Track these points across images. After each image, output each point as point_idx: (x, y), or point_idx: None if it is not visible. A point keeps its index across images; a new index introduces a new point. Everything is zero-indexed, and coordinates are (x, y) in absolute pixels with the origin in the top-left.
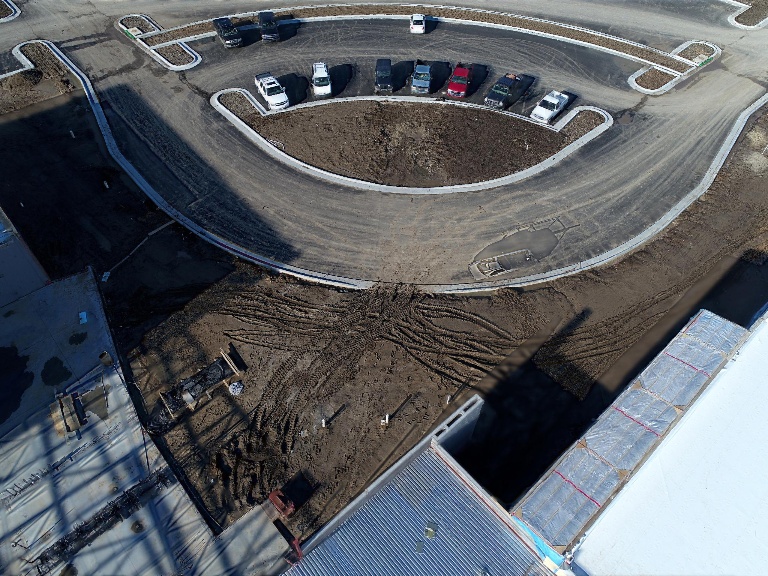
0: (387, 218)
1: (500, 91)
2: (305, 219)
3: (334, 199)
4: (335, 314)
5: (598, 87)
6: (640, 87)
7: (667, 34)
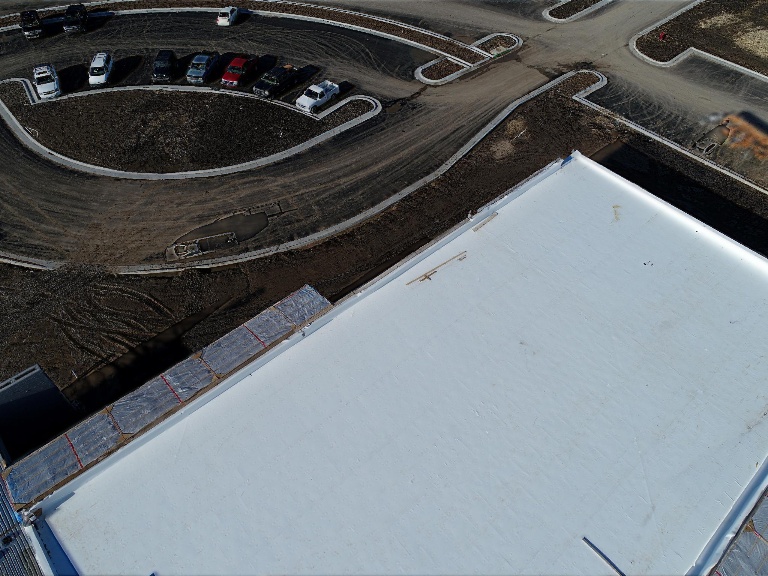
0: (108, 202)
1: (269, 80)
2: (26, 203)
3: (64, 184)
4: (8, 293)
5: (382, 77)
6: (423, 77)
7: (476, 27)
